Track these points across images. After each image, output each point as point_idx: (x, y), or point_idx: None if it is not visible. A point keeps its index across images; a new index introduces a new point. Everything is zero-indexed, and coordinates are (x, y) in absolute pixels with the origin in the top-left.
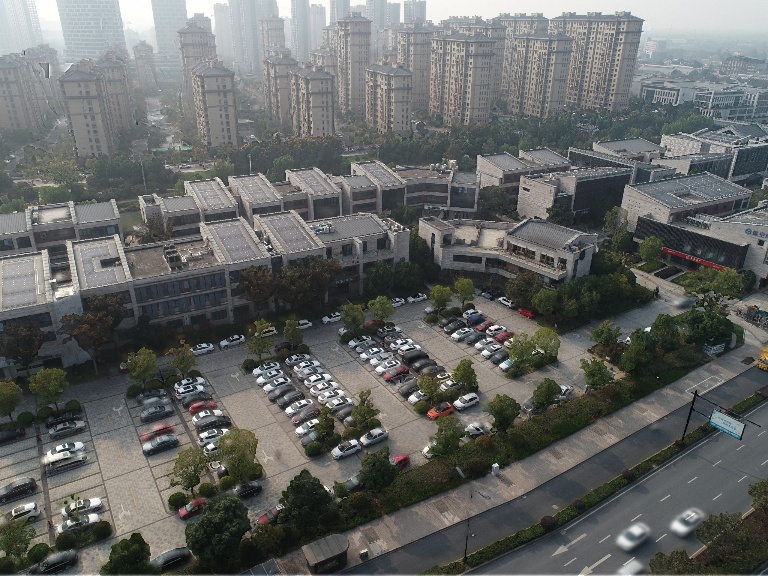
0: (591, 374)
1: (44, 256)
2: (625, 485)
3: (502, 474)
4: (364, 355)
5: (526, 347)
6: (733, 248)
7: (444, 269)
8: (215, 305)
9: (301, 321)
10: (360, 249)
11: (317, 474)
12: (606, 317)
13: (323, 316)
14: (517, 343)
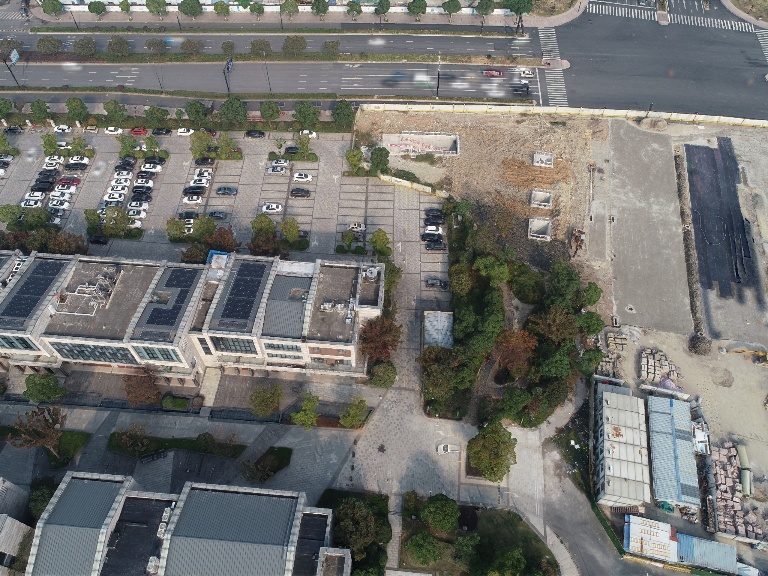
0: (5, 104)
1: (210, 314)
2: None
3: None
4: (66, 204)
5: None
6: None
7: None
8: None
9: None
10: None
11: (174, 146)
12: None
13: None
14: (0, 134)
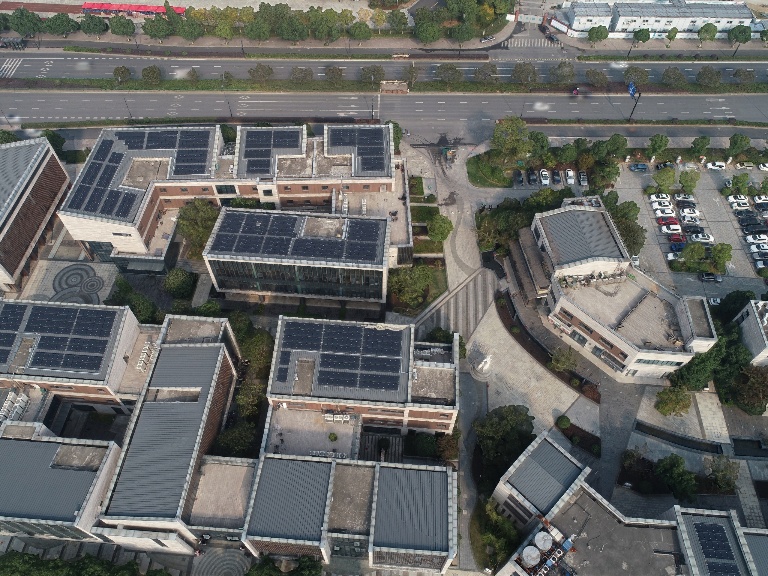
0: None
1: None
2: None
3: None
4: None
5: None
6: None
7: None
8: None
9: None
10: None
11: None
12: None
13: None
14: None
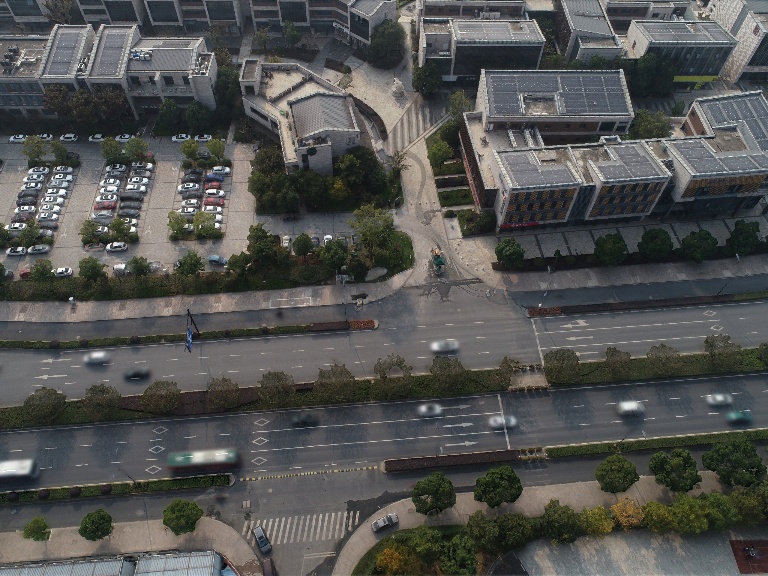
0: (180, 264)
1: None
2: (127, 344)
3: (77, 305)
4: (102, 182)
5: (176, 223)
6: (482, 187)
7: (248, 115)
8: (41, 105)
9: (96, 135)
10: (157, 84)
11: None
12: (317, 211)
13: (120, 134)
14: (168, 218)
